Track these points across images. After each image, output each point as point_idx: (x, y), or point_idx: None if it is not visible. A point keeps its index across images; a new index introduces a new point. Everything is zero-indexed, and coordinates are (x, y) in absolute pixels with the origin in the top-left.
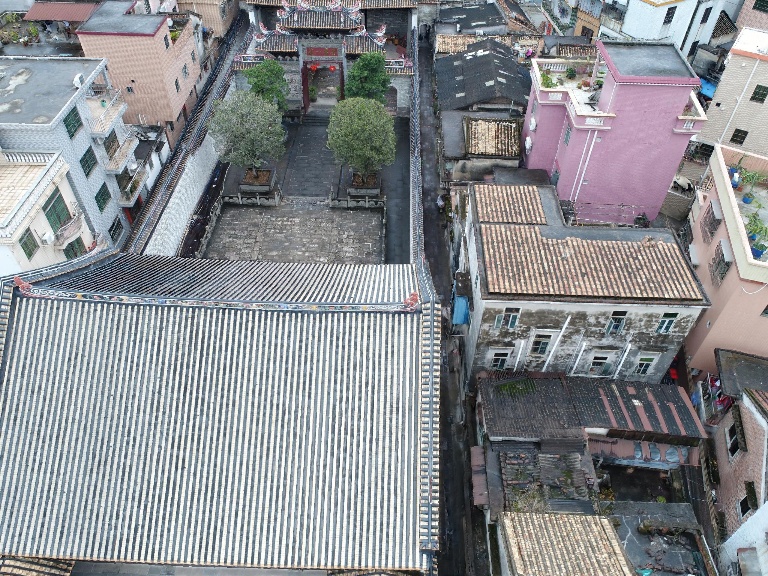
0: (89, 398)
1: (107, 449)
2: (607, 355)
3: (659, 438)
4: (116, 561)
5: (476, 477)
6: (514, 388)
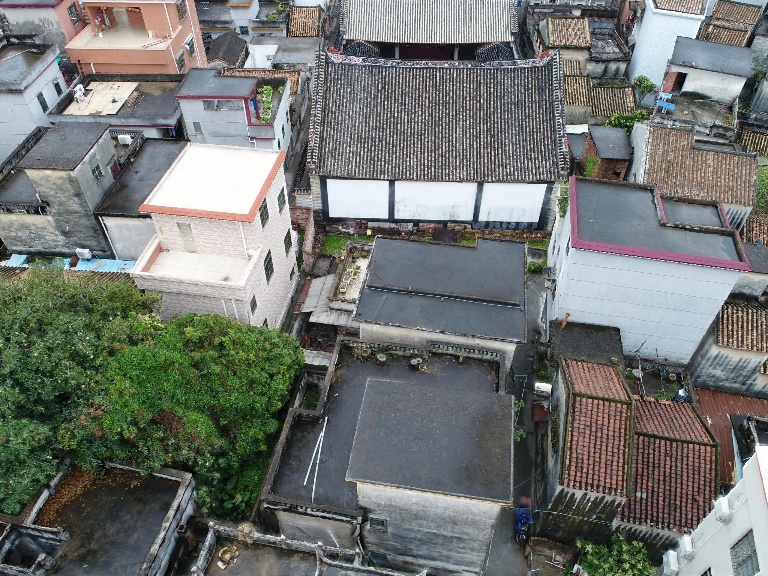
0: None
1: (391, 8)
2: (582, 3)
3: (601, 14)
4: (399, 42)
5: (530, 20)
6: (543, 5)
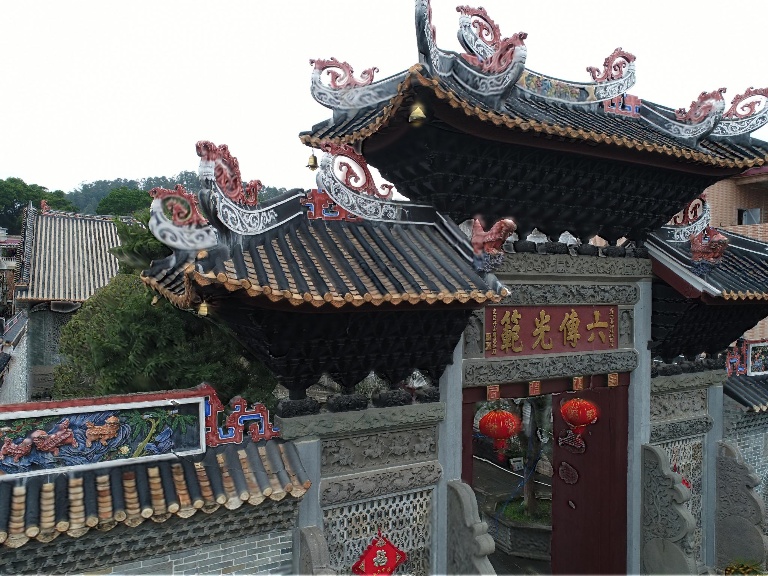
0: None
1: None
2: None
3: None
4: None
5: None
6: None
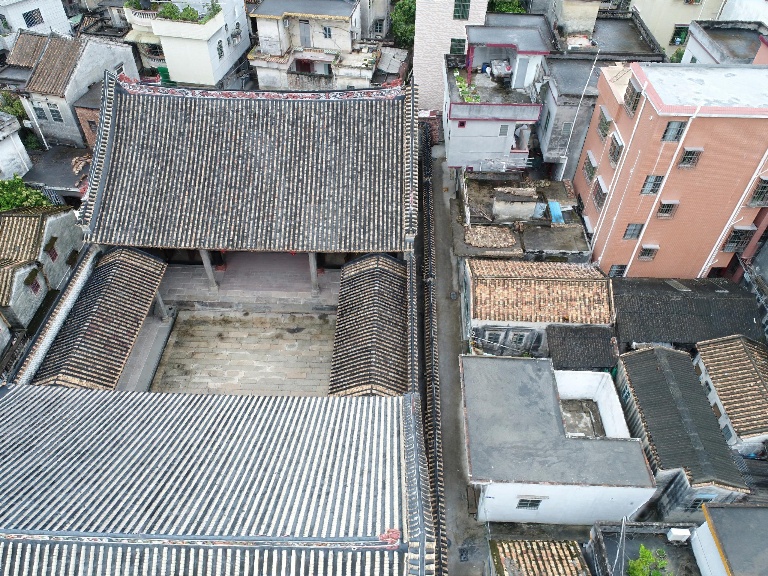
0: (302, 469)
1: (284, 442)
2: None
3: None
4: None
5: None
6: None
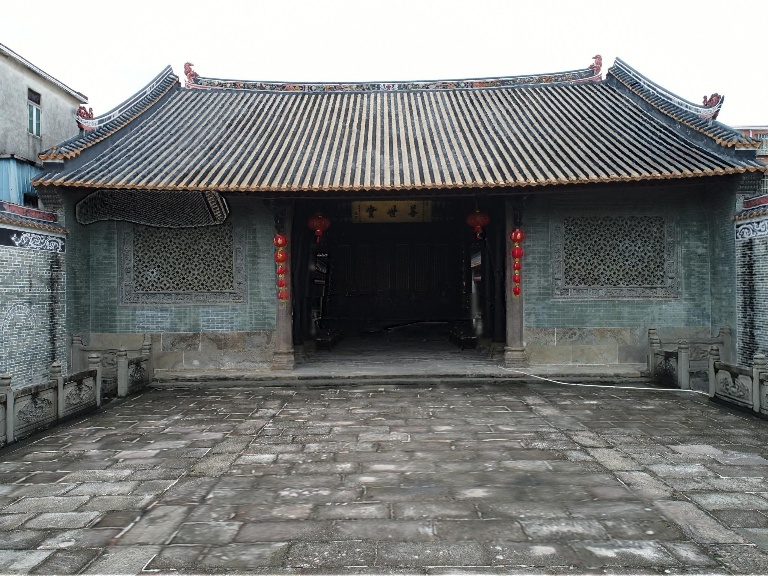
0: None
1: None
2: None
3: None
4: None
5: None
6: None
